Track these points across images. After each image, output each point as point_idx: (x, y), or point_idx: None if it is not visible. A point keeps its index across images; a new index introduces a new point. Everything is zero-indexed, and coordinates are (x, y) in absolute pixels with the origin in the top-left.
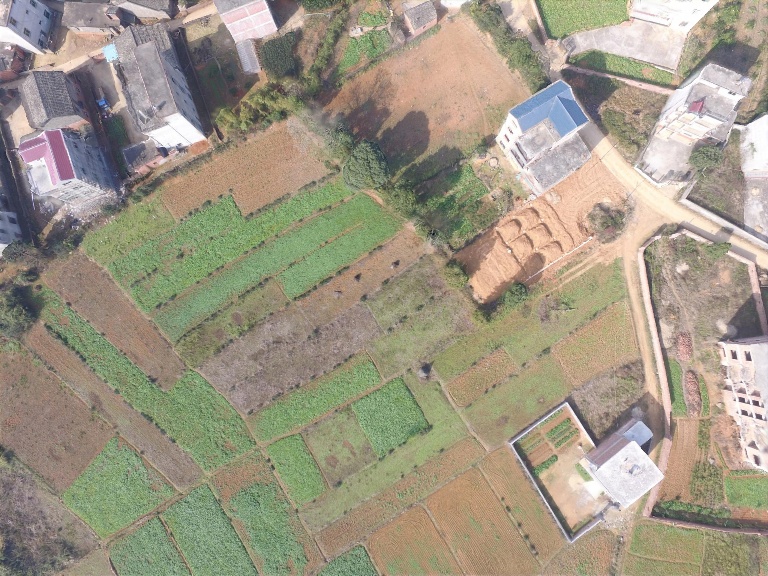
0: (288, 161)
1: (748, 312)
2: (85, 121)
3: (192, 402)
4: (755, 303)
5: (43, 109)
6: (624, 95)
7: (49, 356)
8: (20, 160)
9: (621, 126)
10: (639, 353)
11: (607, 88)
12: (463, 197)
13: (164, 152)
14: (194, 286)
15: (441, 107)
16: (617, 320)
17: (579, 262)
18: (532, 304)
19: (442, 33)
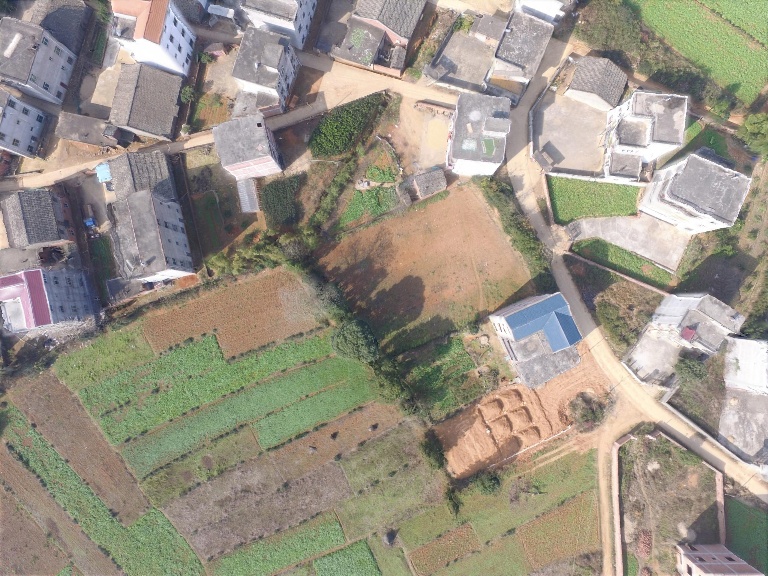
0: (277, 308)
1: (709, 519)
2: (70, 241)
3: (152, 541)
4: (717, 510)
5: (25, 234)
6: (622, 288)
7: (8, 476)
8: None
9: (614, 321)
10: (600, 544)
11: (606, 280)
12: (450, 369)
13: (150, 286)
14: (167, 423)
15: (439, 275)
16: (584, 509)
17: (555, 448)
18: (504, 483)
19: (450, 200)
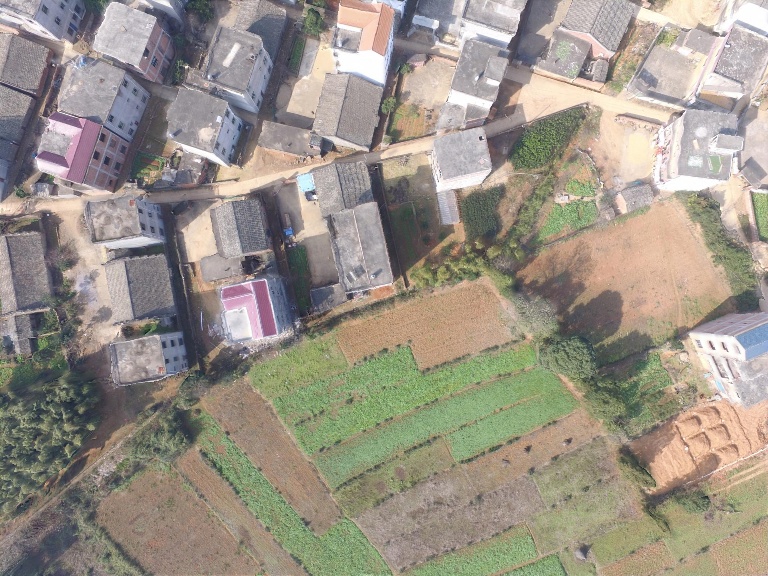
0: (473, 320)
1: None
2: (270, 250)
3: (344, 551)
4: None
5: (238, 243)
6: None
7: (201, 483)
8: (192, 276)
9: None
10: None
11: None
12: (646, 385)
13: (350, 296)
14: (360, 434)
15: (638, 290)
16: None
17: (751, 466)
18: None
19: (650, 214)
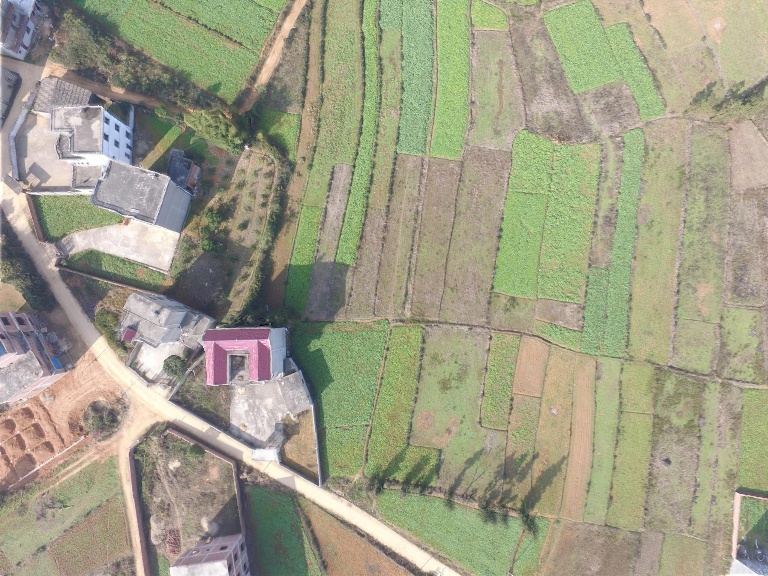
0: None
1: (230, 509)
2: None
3: None
4: None
5: None
6: (120, 295)
7: None
8: None
9: (112, 327)
10: (131, 550)
11: (100, 289)
12: None
13: None
14: None
15: None
16: (111, 517)
17: (75, 460)
18: (29, 502)
19: None
